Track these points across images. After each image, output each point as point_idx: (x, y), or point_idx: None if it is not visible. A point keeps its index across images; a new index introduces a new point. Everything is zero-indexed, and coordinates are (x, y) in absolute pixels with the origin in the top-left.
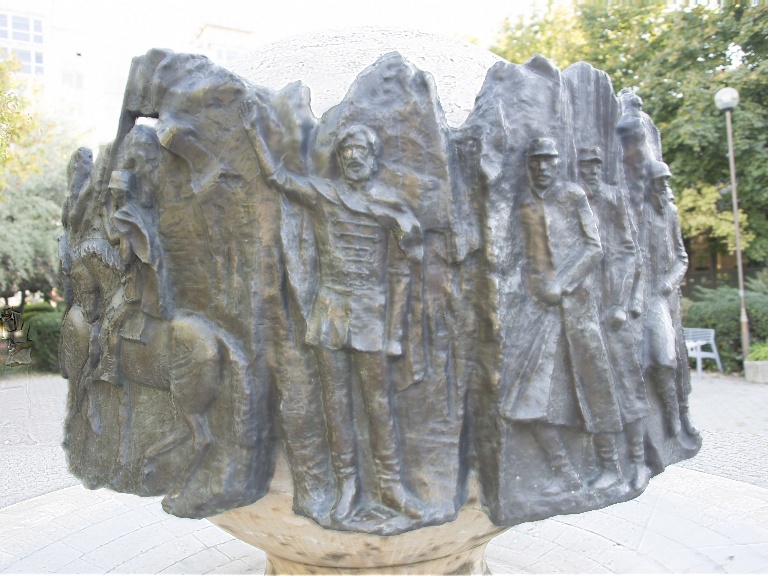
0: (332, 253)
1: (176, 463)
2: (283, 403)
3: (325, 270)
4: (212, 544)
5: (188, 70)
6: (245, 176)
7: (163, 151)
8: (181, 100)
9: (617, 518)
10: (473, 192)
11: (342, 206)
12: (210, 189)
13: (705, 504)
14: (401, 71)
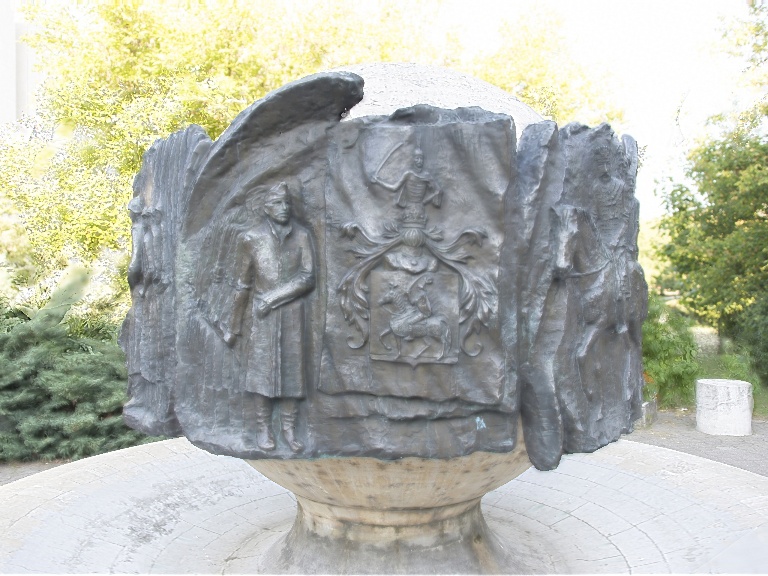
0: None
1: None
2: None
3: None
4: (576, 514)
5: None
6: None
7: None
8: None
9: None
10: None
11: None
12: None
13: None
14: None
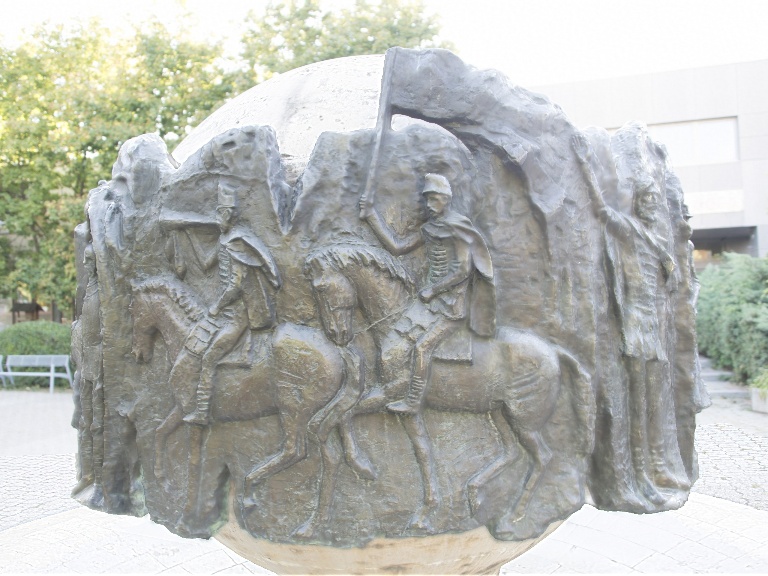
0: (642, 279)
1: (508, 486)
2: (612, 410)
3: (634, 293)
4: None
5: (511, 89)
6: (578, 204)
7: (494, 164)
8: (522, 119)
9: None
10: (675, 238)
11: (646, 240)
12: (557, 211)
13: None
14: (648, 138)
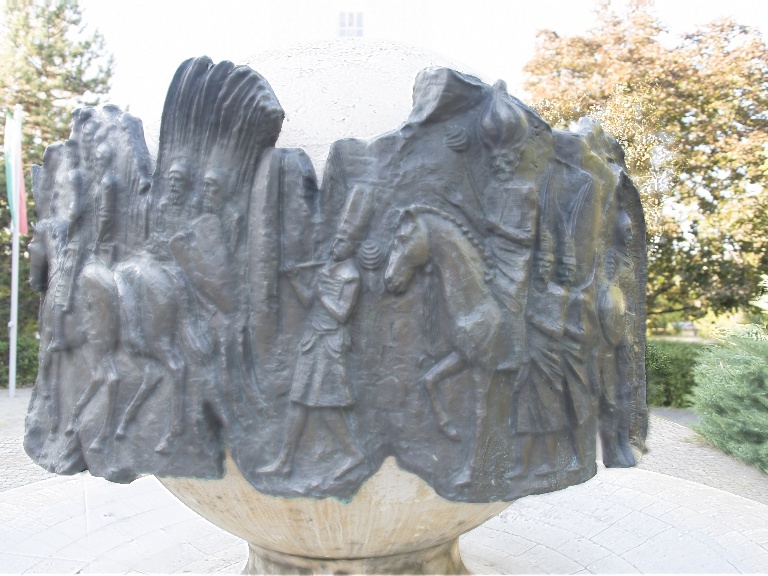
0: None
1: None
2: None
3: None
4: None
5: None
6: None
7: None
8: None
9: (26, 574)
10: None
11: None
12: None
13: (1, 526)
14: None
